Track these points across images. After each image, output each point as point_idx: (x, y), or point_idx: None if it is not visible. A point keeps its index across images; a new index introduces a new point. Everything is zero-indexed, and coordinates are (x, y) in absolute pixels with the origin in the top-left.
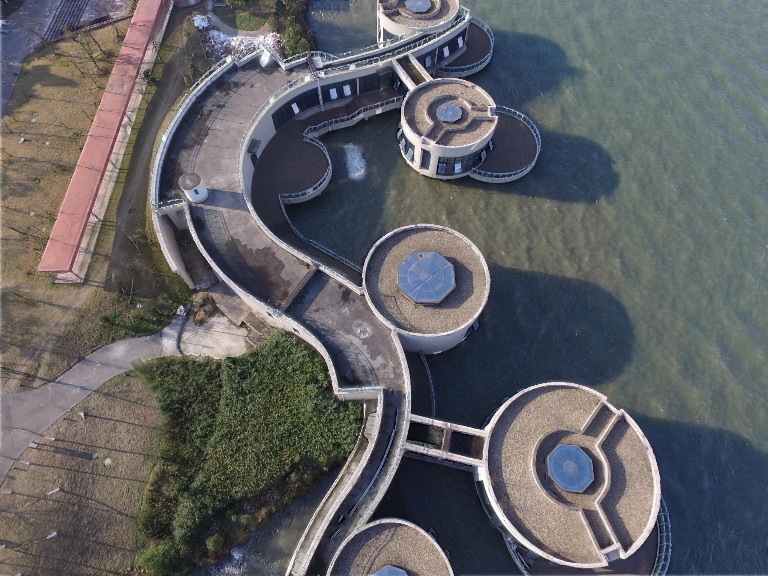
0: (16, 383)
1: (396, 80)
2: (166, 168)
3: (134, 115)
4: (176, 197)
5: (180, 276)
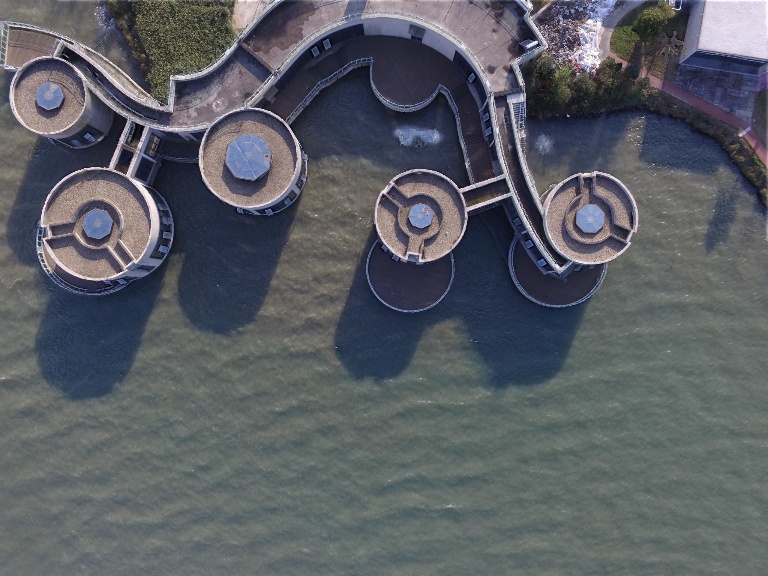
0: None
1: None
2: None
3: None
4: None
5: None
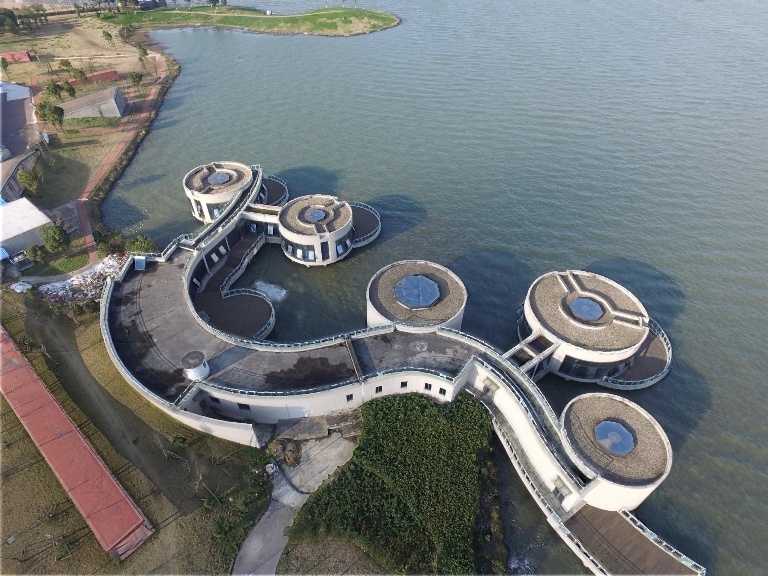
0: None
1: (251, 225)
2: (142, 380)
3: None
4: (180, 390)
5: (241, 447)
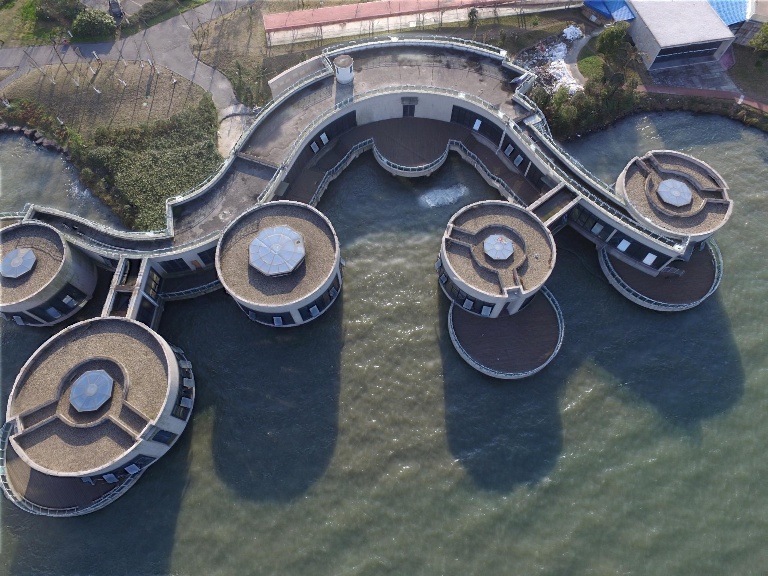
0: (195, 43)
1: None
2: (369, 52)
3: (432, 23)
4: None
5: None
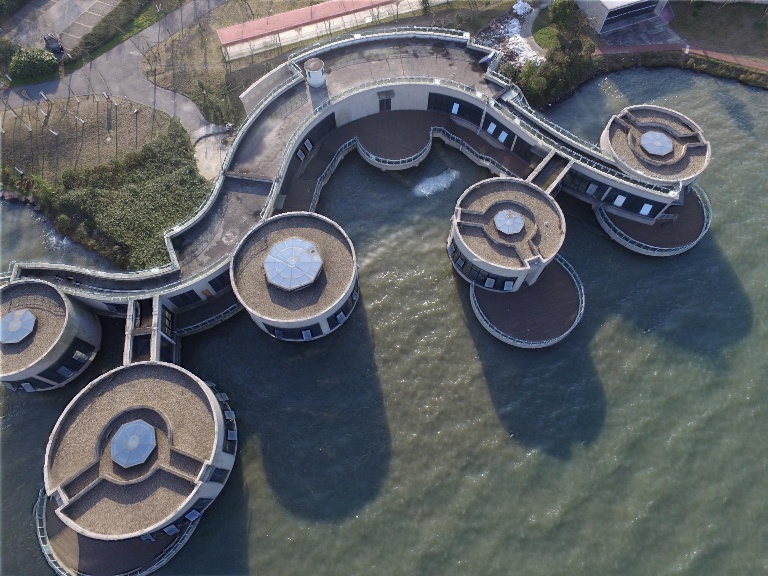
0: (148, 69)
1: None
2: (334, 52)
3: (386, 16)
4: None
5: None
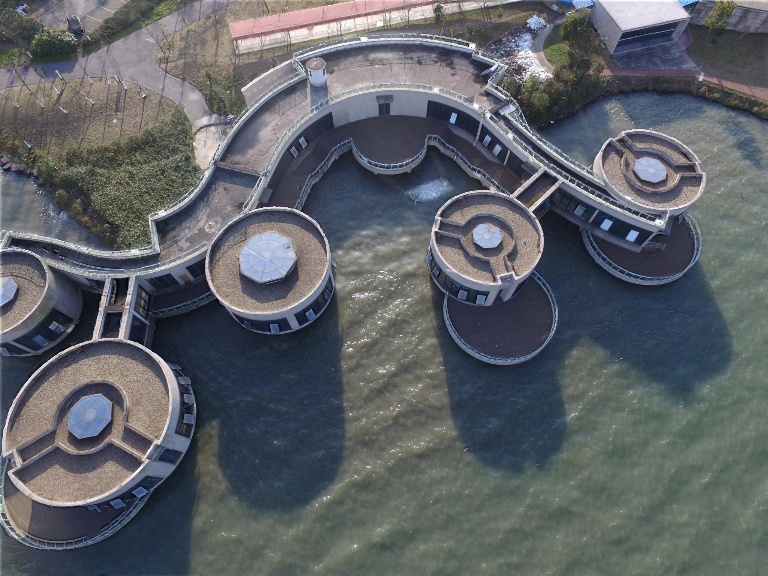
0: (161, 56)
1: None
2: (339, 53)
3: (398, 21)
4: None
5: None
